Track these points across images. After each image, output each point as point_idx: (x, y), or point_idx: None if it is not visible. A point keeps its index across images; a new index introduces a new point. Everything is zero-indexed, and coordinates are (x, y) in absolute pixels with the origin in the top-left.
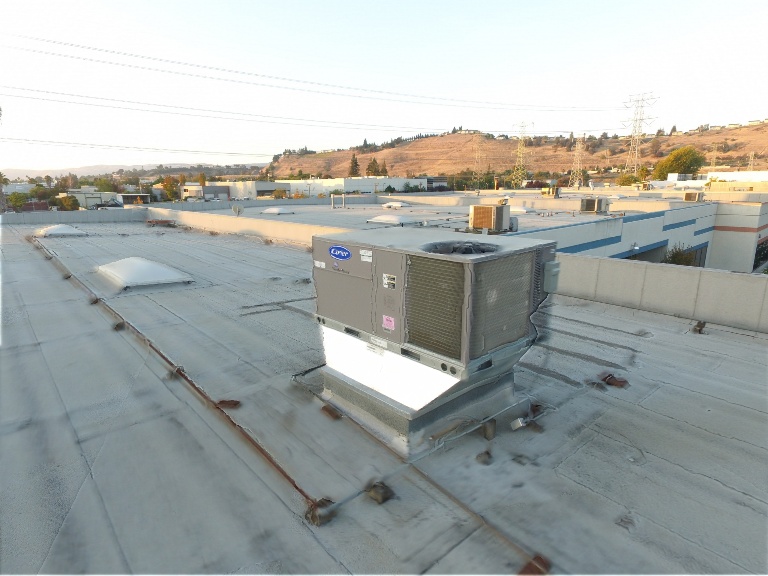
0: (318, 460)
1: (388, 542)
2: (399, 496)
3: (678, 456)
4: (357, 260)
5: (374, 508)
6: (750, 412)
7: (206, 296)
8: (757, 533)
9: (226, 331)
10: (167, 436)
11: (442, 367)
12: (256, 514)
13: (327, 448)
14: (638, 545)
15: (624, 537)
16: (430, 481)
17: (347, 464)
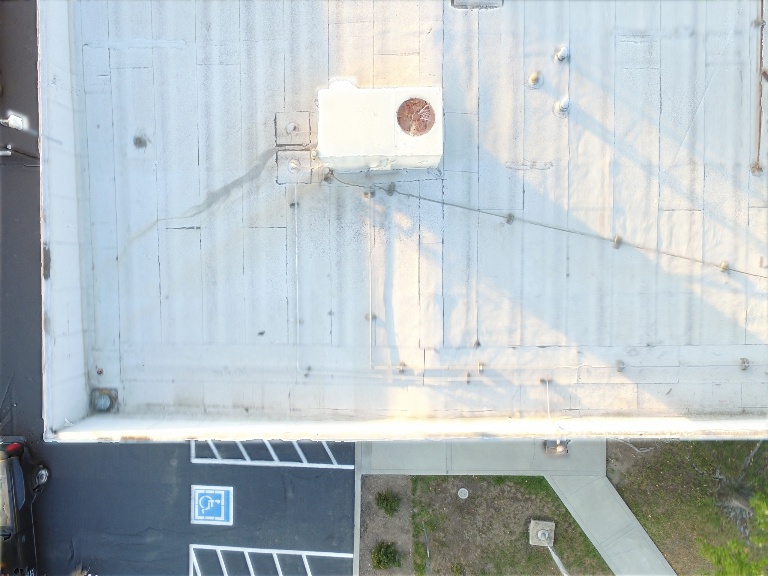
0: None
1: (764, 193)
2: None
3: None
4: None
5: None
6: None
7: None
8: None
9: None
10: (734, 87)
11: None
12: (740, 156)
13: None
14: None
15: None
16: None
17: None
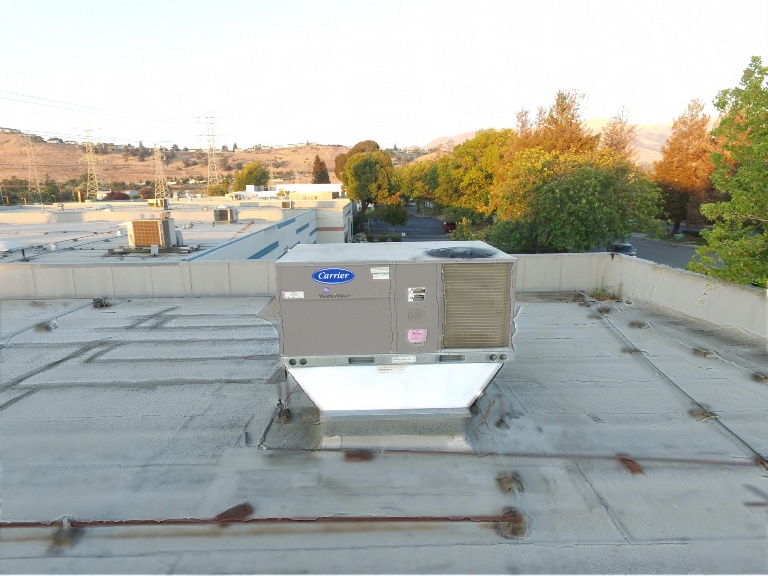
0: (428, 497)
1: (567, 510)
2: (518, 480)
3: (547, 377)
4: (368, 280)
5: (526, 497)
6: (525, 341)
7: None
8: (624, 396)
9: (4, 448)
10: None
11: (491, 358)
12: (475, 570)
13: (412, 485)
14: (621, 427)
15: (612, 427)
16: (520, 456)
17: (449, 485)
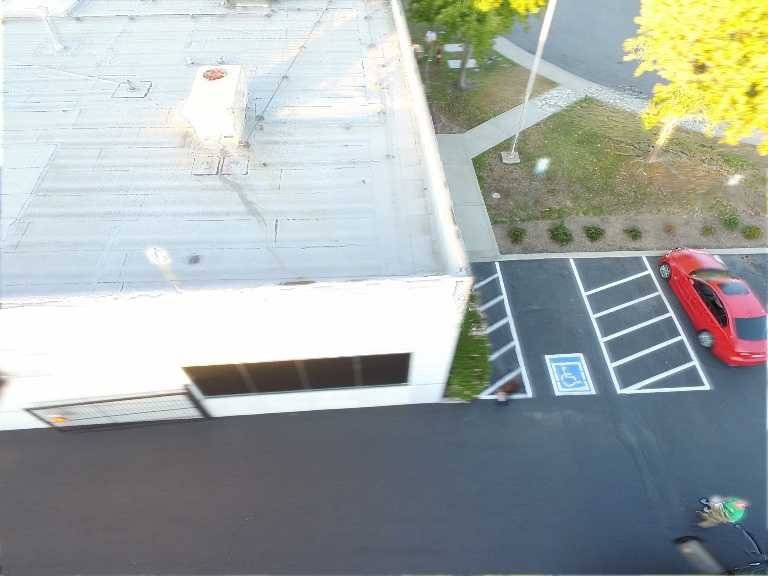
0: None
1: None
2: None
3: None
4: None
5: (274, 13)
6: None
7: (110, 3)
8: None
9: (168, 7)
10: None
11: None
12: None
13: None
14: (307, 4)
15: (305, 4)
16: None
17: None
